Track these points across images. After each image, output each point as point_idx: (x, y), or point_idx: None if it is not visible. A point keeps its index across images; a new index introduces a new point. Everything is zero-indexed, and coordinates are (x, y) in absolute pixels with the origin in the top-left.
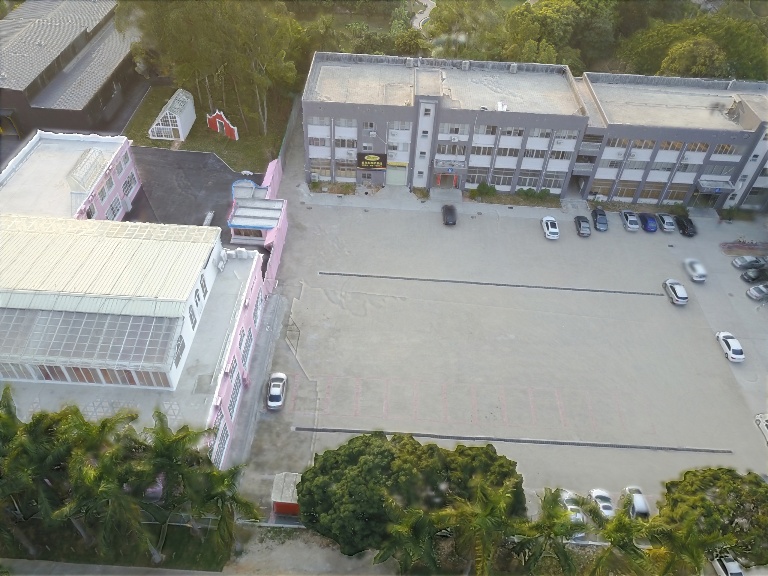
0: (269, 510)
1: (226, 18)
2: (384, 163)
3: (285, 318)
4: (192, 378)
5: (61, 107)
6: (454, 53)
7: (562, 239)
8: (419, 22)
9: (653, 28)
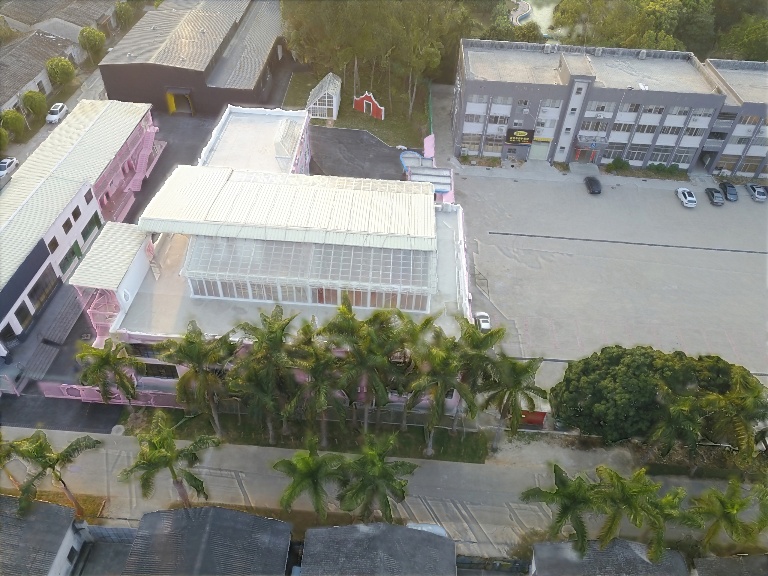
0: (505, 420)
1: (400, 5)
2: (530, 138)
3: (471, 269)
4: (440, 304)
5: (233, 87)
6: (580, 42)
7: (698, 207)
8: (515, 19)
9: (749, 23)
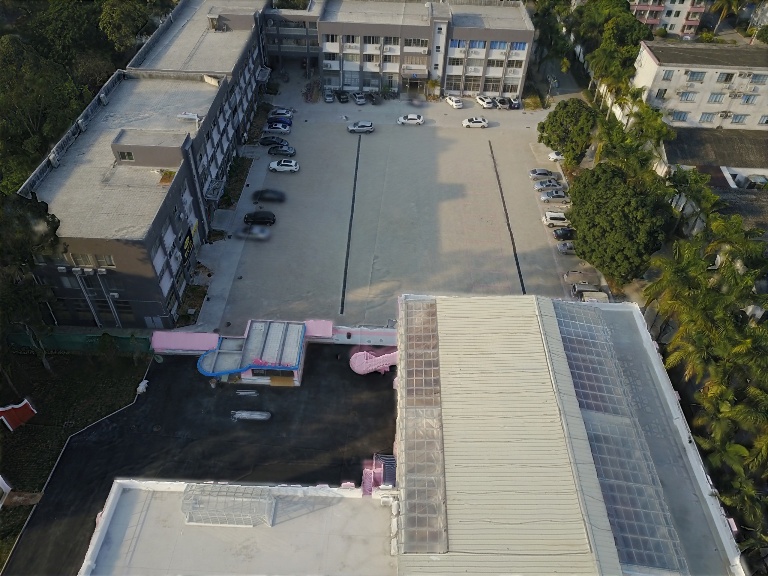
0: None
1: None
2: (191, 239)
3: None
4: None
5: None
6: (18, 138)
7: None
8: None
9: (1, 31)
